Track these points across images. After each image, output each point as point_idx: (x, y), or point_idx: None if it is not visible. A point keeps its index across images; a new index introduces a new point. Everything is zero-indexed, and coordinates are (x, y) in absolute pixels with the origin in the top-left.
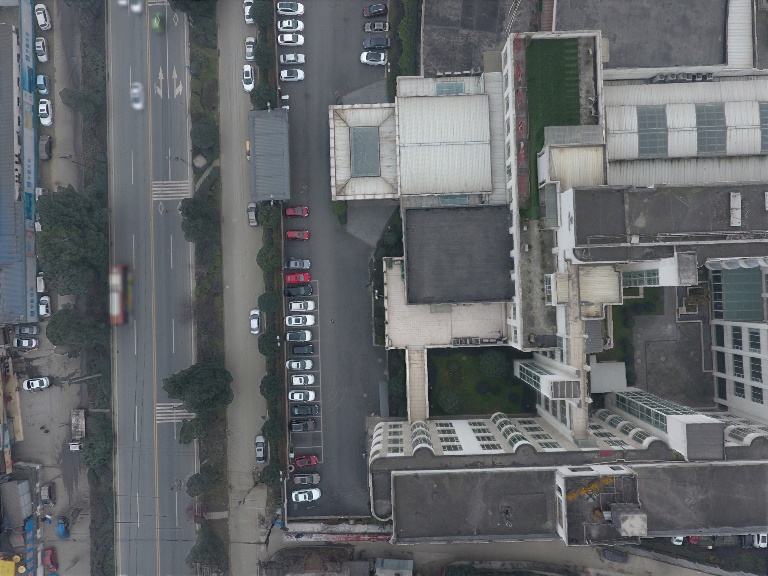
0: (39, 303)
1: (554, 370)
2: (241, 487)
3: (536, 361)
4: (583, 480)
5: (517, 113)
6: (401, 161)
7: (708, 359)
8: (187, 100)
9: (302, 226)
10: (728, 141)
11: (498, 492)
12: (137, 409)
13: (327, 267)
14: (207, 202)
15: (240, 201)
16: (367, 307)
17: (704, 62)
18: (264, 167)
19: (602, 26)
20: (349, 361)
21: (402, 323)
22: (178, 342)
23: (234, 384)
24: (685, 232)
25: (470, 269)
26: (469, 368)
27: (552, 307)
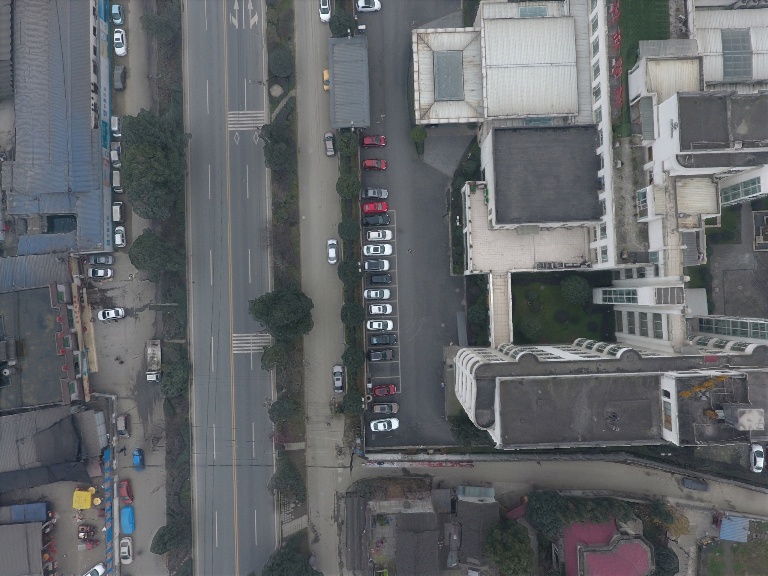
0: (114, 233)
1: (647, 286)
2: (318, 418)
3: (619, 286)
4: (693, 381)
5: None
6: (488, 82)
7: None
8: (263, 30)
9: (379, 156)
10: None
11: (603, 398)
12: (213, 340)
13: (404, 197)
14: None
15: (316, 131)
16: (444, 237)
17: None
18: (343, 95)
19: None
20: (427, 291)
21: (485, 248)
22: (254, 272)
23: (311, 314)
24: None
25: (557, 190)
26: (547, 297)
27: (644, 224)
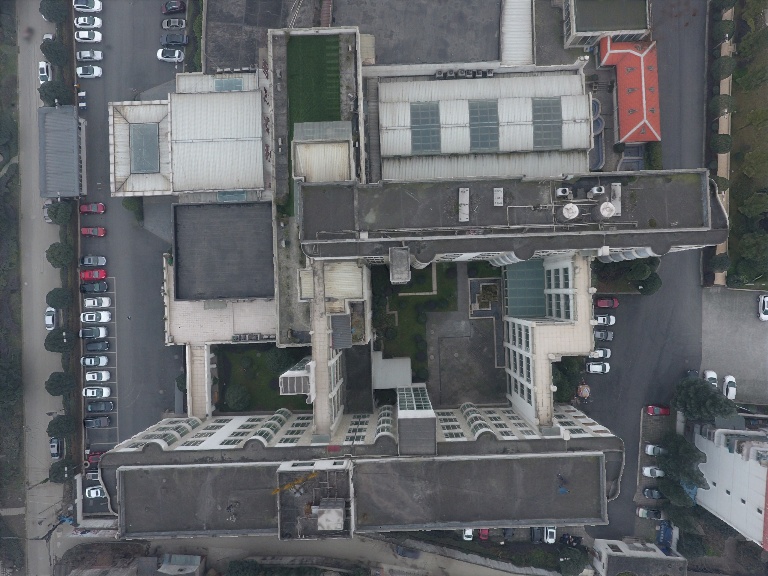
0: None
1: None
2: None
3: None
4: (298, 475)
5: (278, 109)
6: (173, 157)
7: (501, 355)
8: None
9: (99, 223)
10: (501, 137)
11: (227, 487)
12: None
13: (124, 264)
14: (3, 199)
15: (39, 198)
16: None
17: (480, 58)
18: (55, 164)
19: (379, 22)
20: (145, 357)
21: (184, 319)
22: None
23: (32, 381)
24: (413, 228)
25: (241, 265)
26: (263, 364)
27: None
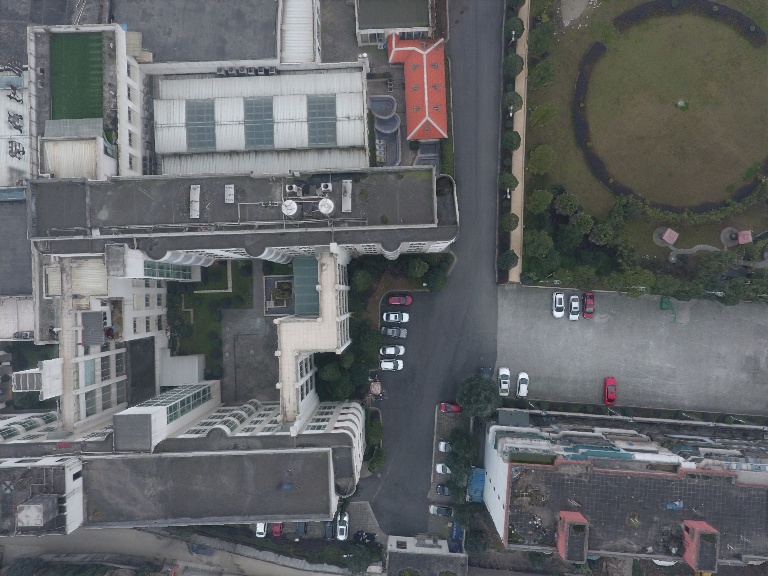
0: None
1: None
2: None
3: None
4: (17, 471)
5: (41, 107)
6: None
7: None
8: None
9: None
10: (276, 135)
11: None
12: None
13: None
14: None
15: None
16: None
17: (258, 56)
18: None
19: (158, 20)
20: None
21: None
22: None
23: None
24: (145, 224)
25: (13, 263)
26: None
27: None
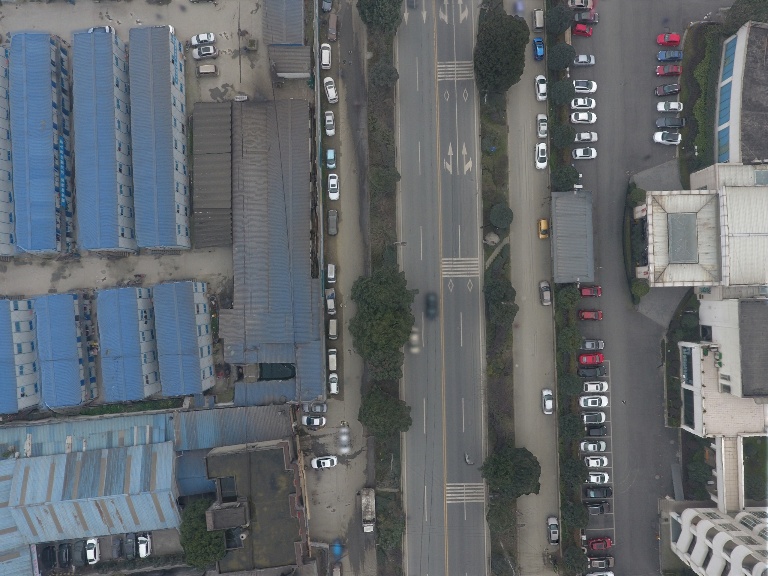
0: (329, 381)
1: None
2: (531, 569)
3: None
4: None
5: None
6: (729, 251)
7: None
8: (477, 176)
9: (593, 305)
10: None
11: None
12: (426, 489)
13: (618, 347)
14: None
15: (529, 279)
16: (659, 388)
17: None
18: (566, 248)
19: None
20: (641, 442)
21: (715, 410)
22: (468, 421)
23: None
24: None
25: None
26: (764, 451)
27: None
